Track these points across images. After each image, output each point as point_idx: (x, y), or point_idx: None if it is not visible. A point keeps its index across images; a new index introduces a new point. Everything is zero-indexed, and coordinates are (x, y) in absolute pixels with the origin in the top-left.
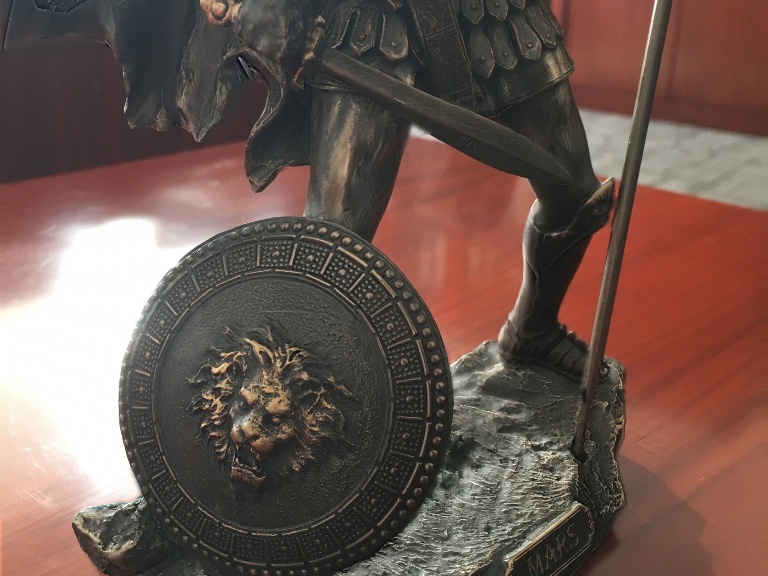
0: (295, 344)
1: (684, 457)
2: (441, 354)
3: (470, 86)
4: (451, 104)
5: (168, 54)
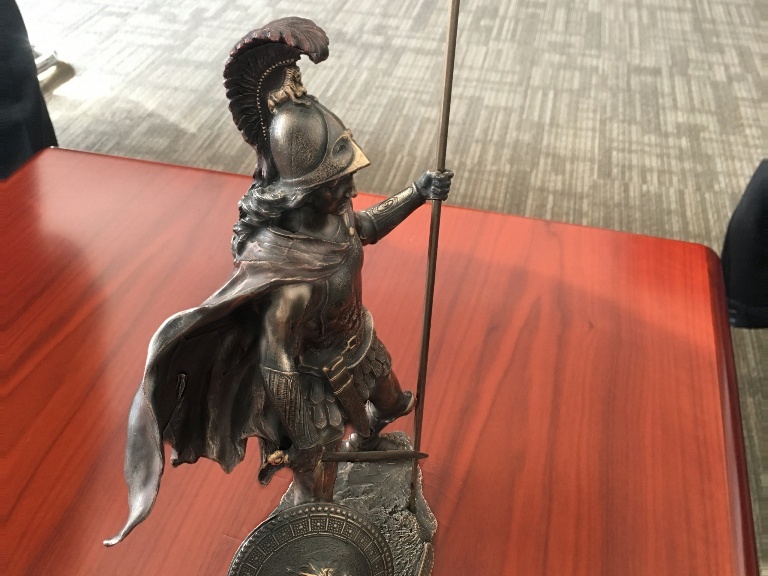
0: (325, 567)
1: (447, 471)
2: (384, 541)
3: (365, 413)
4: (378, 452)
5: (193, 430)
